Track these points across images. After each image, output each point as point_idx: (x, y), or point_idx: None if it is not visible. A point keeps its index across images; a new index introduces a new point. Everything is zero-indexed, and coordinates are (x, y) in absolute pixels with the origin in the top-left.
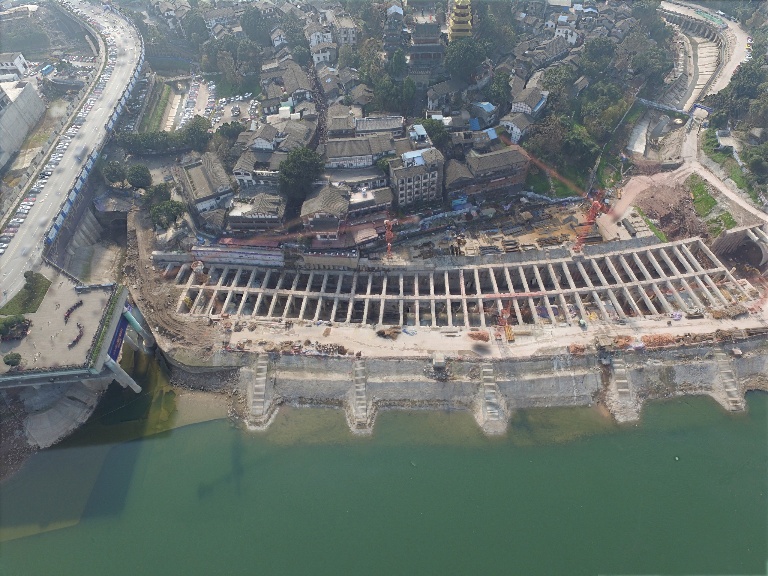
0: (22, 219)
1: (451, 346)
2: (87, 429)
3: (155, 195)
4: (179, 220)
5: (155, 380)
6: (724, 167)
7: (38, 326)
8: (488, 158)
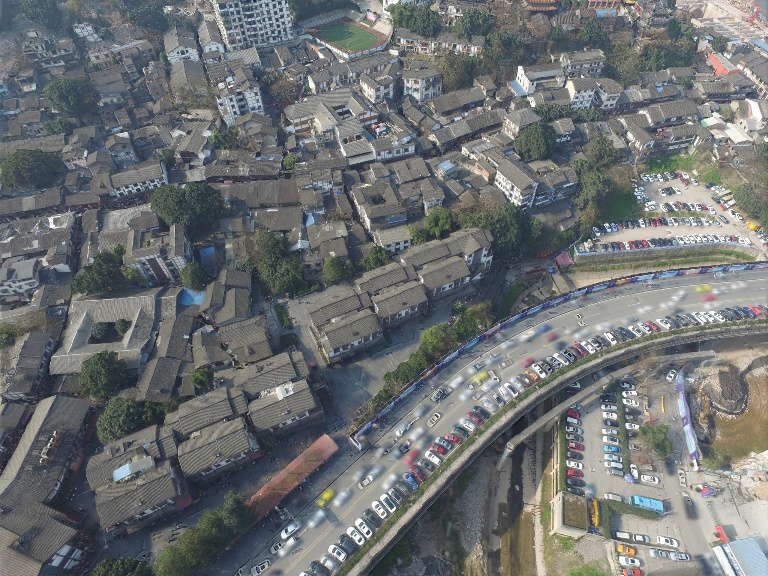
0: None
1: None
2: None
3: None
4: None
5: None
6: None
7: None
8: None
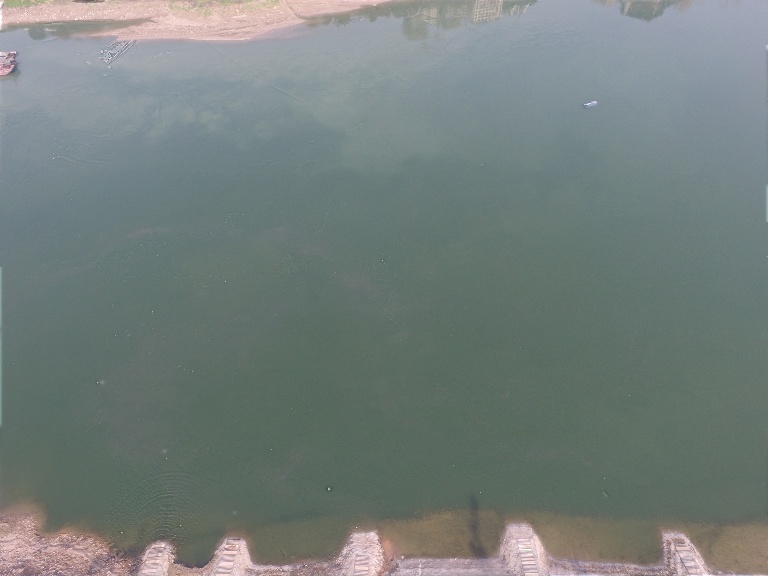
0: None
1: None
2: None
3: None
4: None
5: None
6: None
7: None
8: None
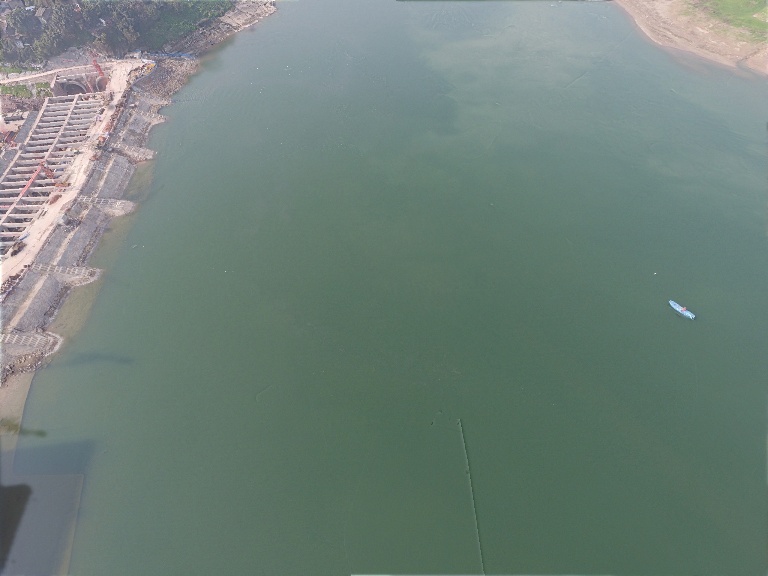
0: None
1: (54, 214)
2: None
3: None
4: None
5: None
6: None
7: None
8: None
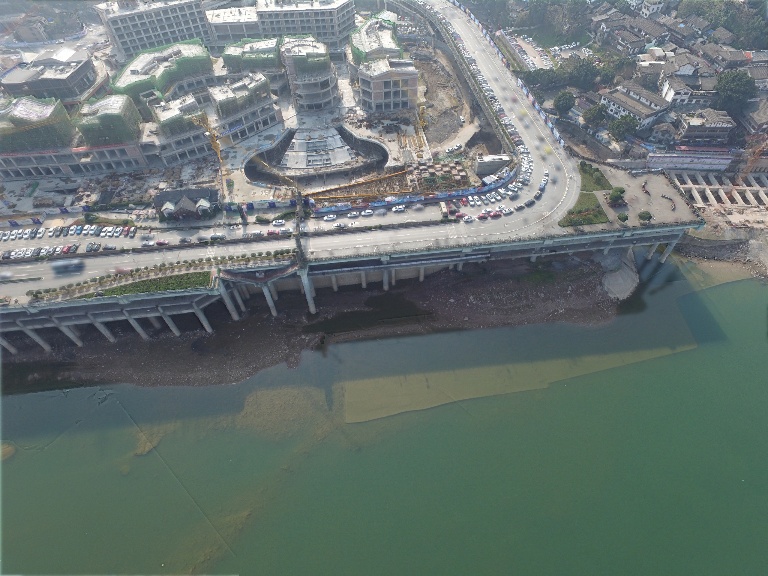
0: (516, 129)
1: None
2: (644, 287)
3: None
4: None
5: None
6: None
7: (629, 197)
8: None
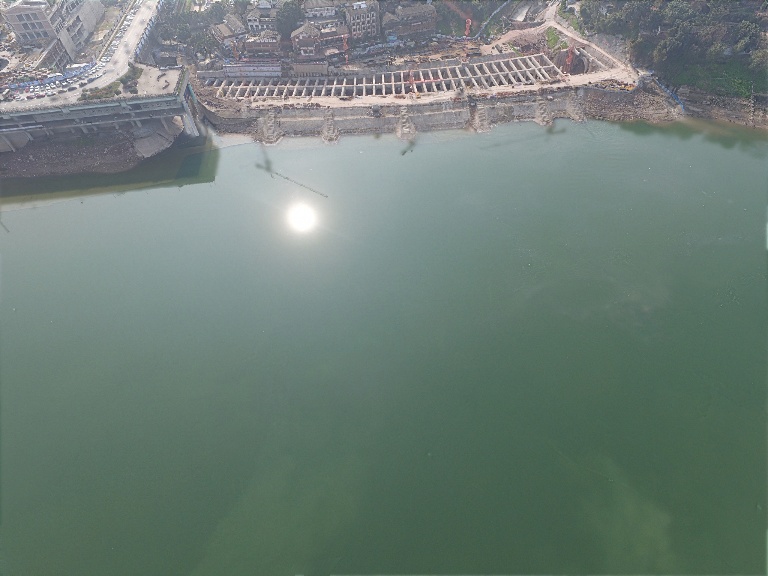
0: (115, 48)
1: (383, 101)
2: (170, 150)
3: (196, 39)
4: (212, 55)
5: (207, 131)
6: (568, 20)
7: (142, 83)
8: (409, 8)
